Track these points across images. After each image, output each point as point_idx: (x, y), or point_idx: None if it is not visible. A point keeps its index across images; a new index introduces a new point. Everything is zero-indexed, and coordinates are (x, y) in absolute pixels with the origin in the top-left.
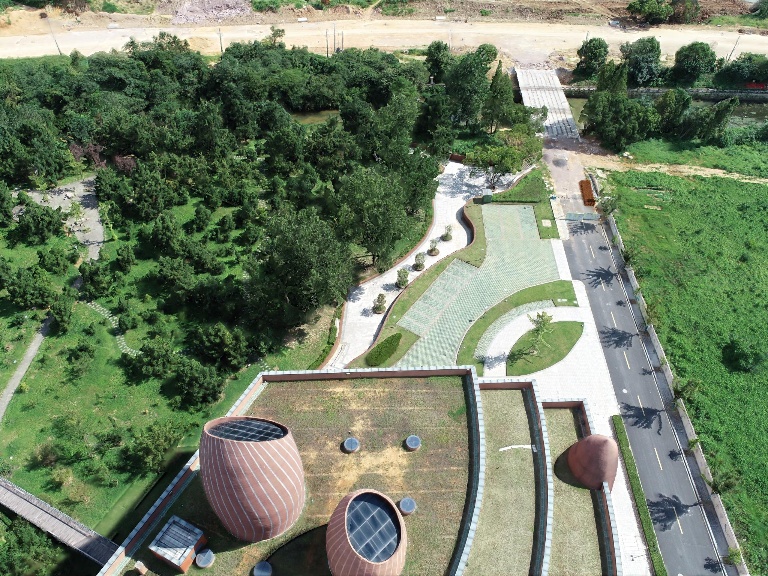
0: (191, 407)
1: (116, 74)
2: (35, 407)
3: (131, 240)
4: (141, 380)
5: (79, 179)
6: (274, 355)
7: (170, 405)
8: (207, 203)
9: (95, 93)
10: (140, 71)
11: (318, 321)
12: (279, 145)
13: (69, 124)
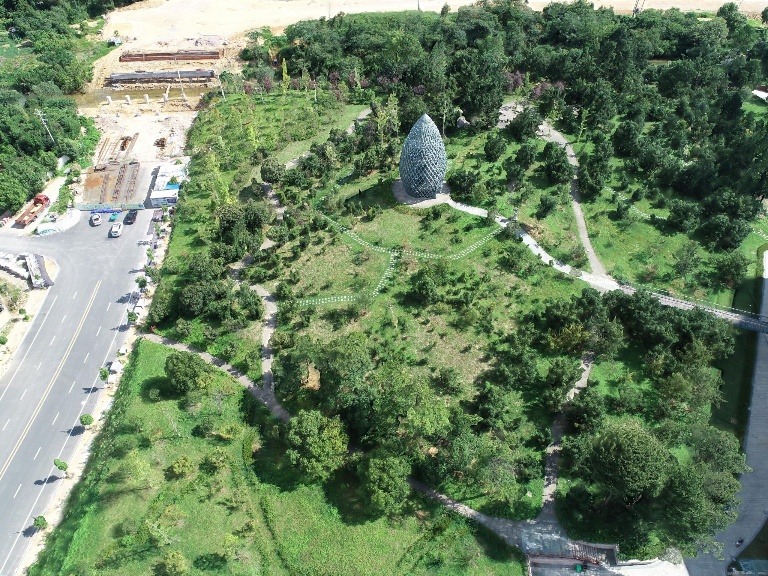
0: (723, 251)
1: (483, 24)
2: (613, 246)
3: (588, 143)
4: (671, 233)
5: (510, 100)
6: (752, 222)
7: (706, 249)
8: (627, 119)
9: (489, 36)
10: (494, 23)
11: (767, 202)
12: (678, 74)
13: (485, 58)
